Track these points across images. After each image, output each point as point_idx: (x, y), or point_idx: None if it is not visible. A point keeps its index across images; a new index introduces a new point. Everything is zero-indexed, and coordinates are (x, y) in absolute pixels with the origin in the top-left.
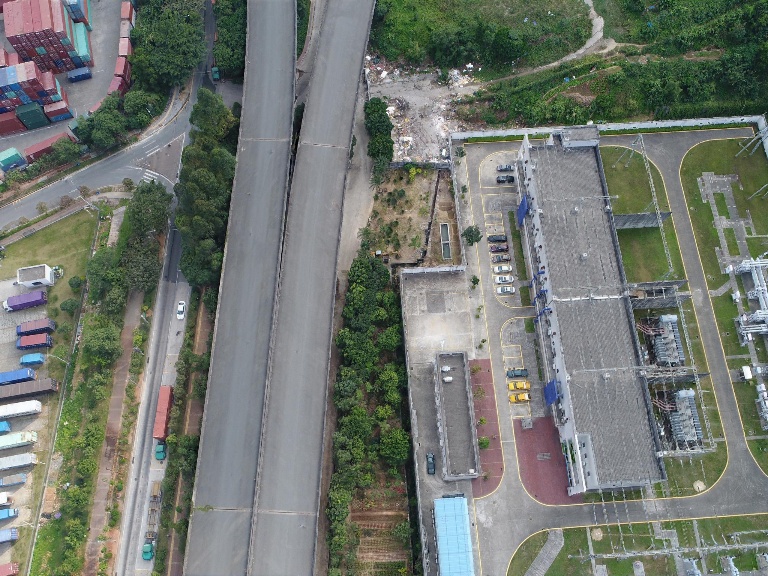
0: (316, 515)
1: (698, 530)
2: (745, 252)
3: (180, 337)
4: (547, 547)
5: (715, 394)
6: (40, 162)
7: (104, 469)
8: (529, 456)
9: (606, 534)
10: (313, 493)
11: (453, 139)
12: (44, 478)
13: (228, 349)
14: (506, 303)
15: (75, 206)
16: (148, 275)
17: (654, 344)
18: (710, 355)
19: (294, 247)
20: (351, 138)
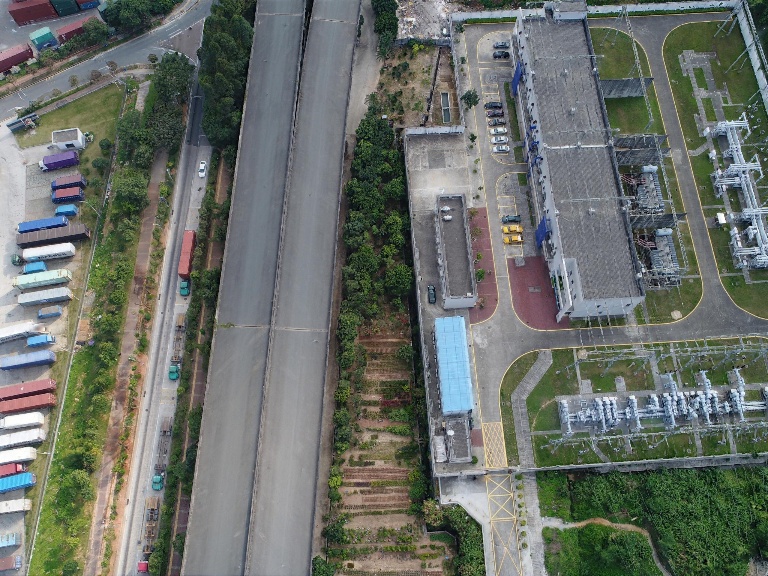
0: (328, 331)
1: (675, 351)
2: (721, 118)
3: (202, 192)
4: (537, 365)
5: (692, 238)
6: (71, 42)
7: (133, 304)
8: (521, 289)
9: (591, 354)
10: (325, 313)
11: (453, 20)
12: (78, 311)
13: (247, 192)
14: (501, 160)
15: (104, 81)
16: (173, 133)
17: (636, 194)
18: (688, 205)
19: (307, 107)
20: (359, 14)
